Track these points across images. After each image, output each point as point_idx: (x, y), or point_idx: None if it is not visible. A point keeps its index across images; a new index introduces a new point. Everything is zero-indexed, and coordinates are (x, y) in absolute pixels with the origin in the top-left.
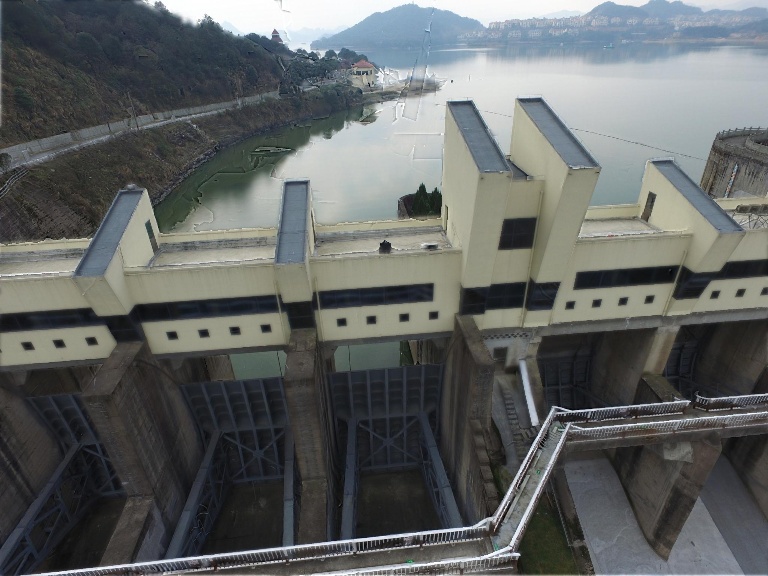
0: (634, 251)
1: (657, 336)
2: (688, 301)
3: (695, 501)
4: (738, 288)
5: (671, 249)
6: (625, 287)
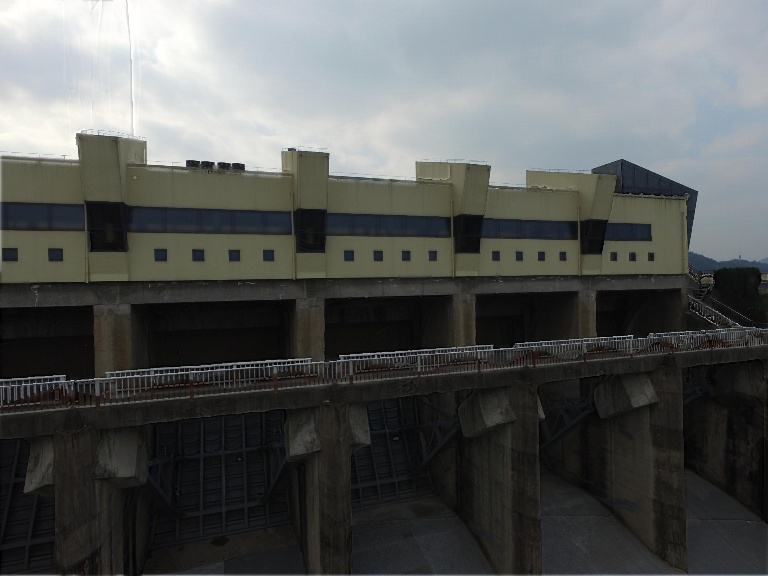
0: (3, 176)
1: (97, 321)
2: (112, 256)
3: (66, 571)
4: (192, 248)
5: (63, 180)
6: (6, 231)
